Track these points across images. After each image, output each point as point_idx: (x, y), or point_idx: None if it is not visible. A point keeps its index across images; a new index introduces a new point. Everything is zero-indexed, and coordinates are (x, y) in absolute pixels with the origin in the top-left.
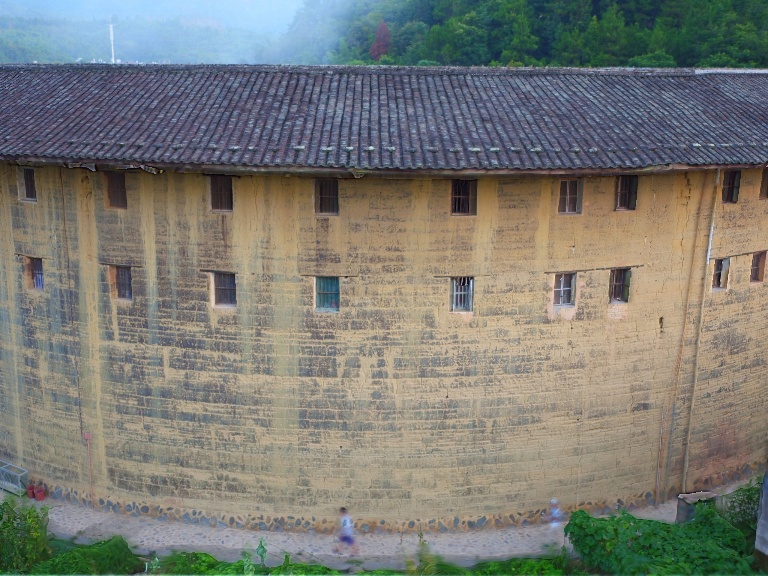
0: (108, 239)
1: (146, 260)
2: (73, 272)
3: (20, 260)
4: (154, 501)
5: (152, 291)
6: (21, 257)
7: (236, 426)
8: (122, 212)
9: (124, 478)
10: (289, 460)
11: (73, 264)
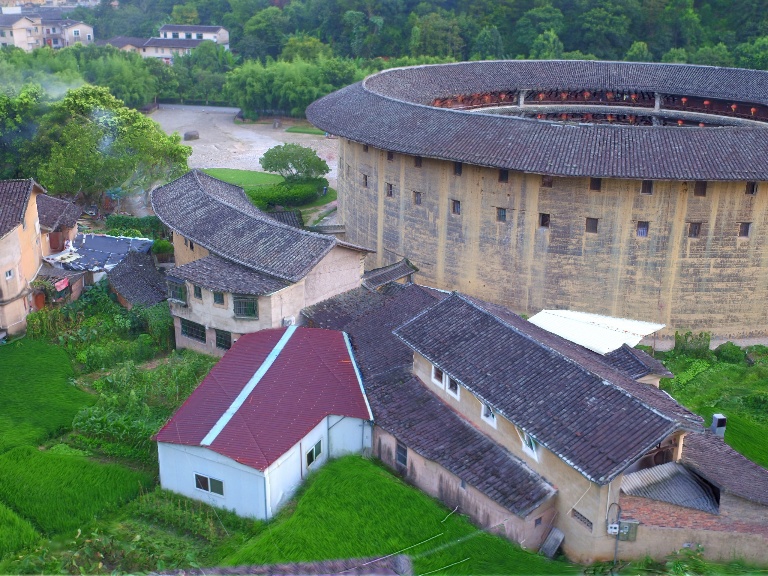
0: (693, 211)
1: (711, 219)
2: (669, 227)
3: (634, 223)
4: (694, 332)
5: (711, 233)
6: (636, 222)
7: (740, 292)
8: (703, 198)
9: (680, 323)
10: (760, 305)
11: (669, 223)
